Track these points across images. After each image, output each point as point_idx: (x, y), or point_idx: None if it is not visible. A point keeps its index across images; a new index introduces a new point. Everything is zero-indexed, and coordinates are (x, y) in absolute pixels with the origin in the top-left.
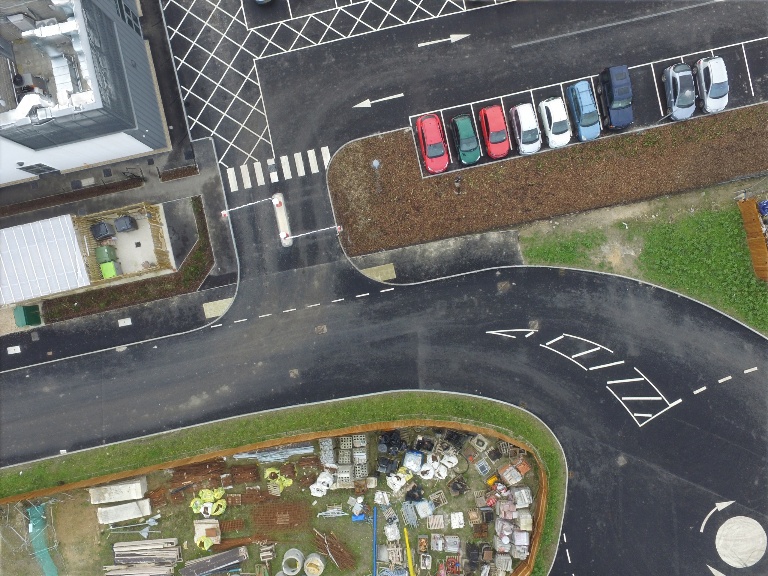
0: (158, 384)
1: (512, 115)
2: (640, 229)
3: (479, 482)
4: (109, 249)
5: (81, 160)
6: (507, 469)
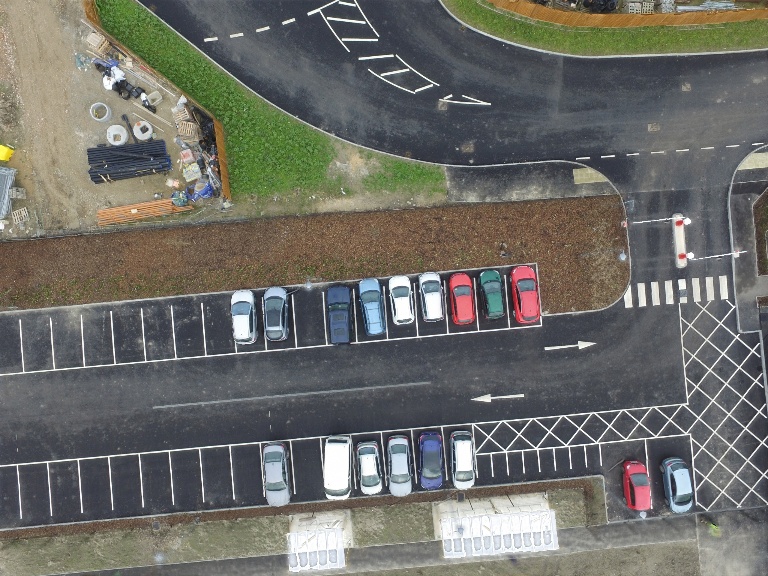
0: None
1: None
2: (329, 186)
3: None
4: None
5: None
6: None
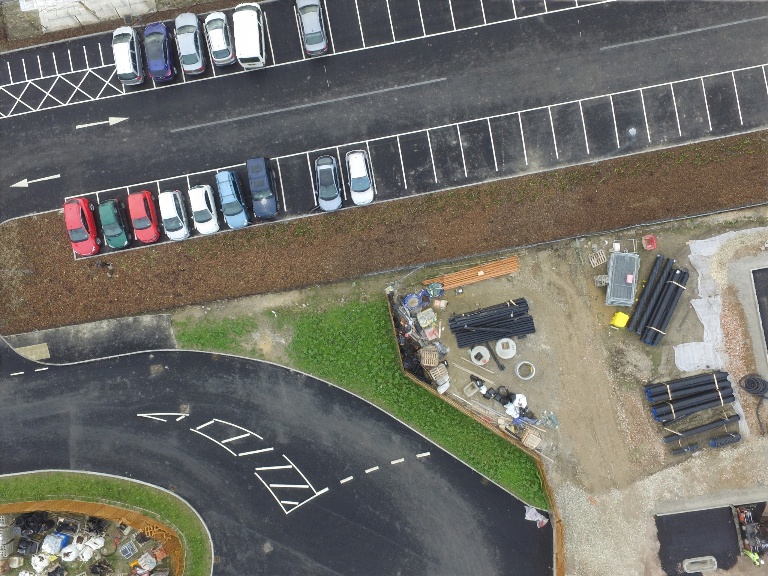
0: None
1: None
2: (289, 318)
3: (126, 564)
4: None
5: None
6: (142, 555)
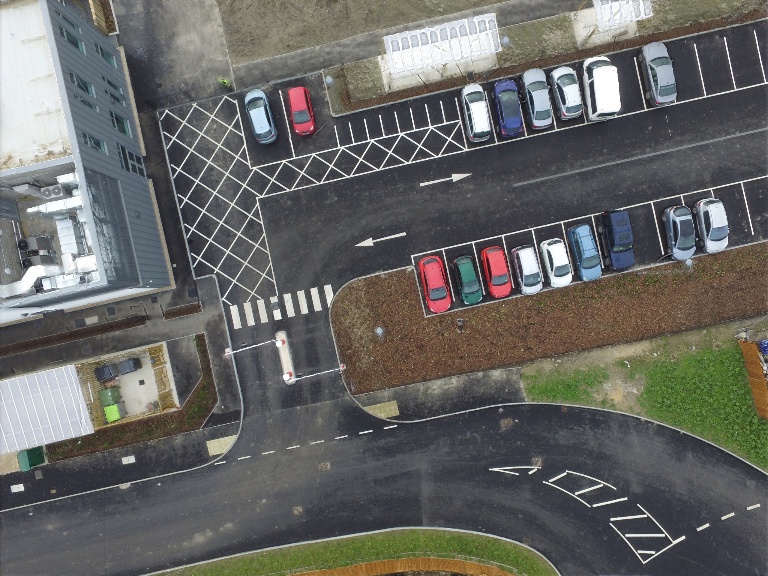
0: (162, 521)
1: (514, 257)
2: (642, 367)
3: None
4: (113, 391)
5: (85, 302)
6: None
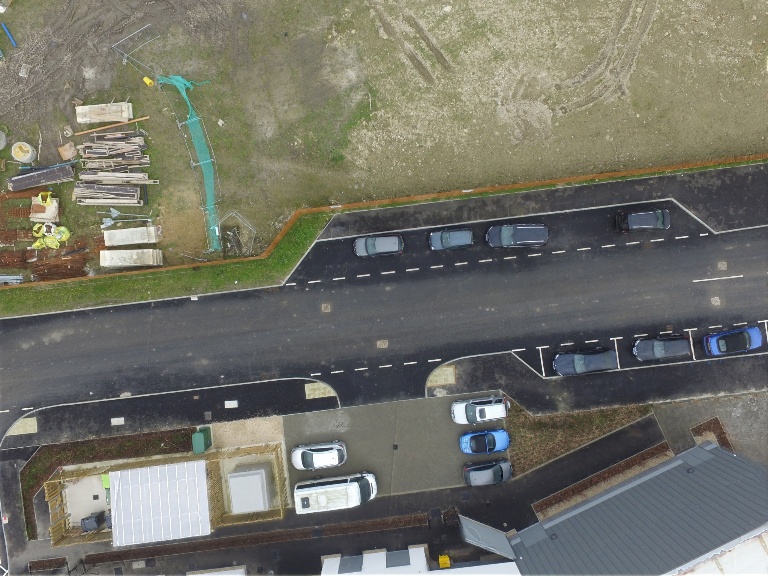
0: (92, 357)
1: None
2: None
3: None
4: None
5: None
6: None
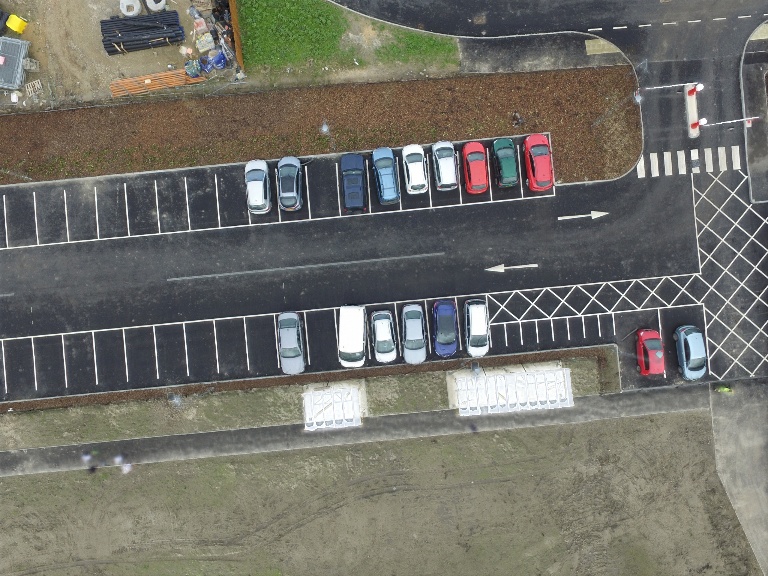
0: None
1: None
2: (342, 57)
3: None
4: None
5: None
6: None
